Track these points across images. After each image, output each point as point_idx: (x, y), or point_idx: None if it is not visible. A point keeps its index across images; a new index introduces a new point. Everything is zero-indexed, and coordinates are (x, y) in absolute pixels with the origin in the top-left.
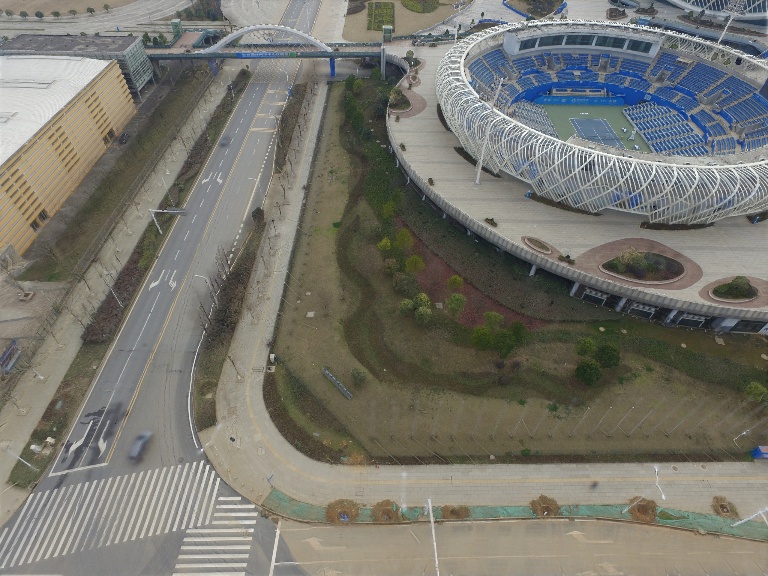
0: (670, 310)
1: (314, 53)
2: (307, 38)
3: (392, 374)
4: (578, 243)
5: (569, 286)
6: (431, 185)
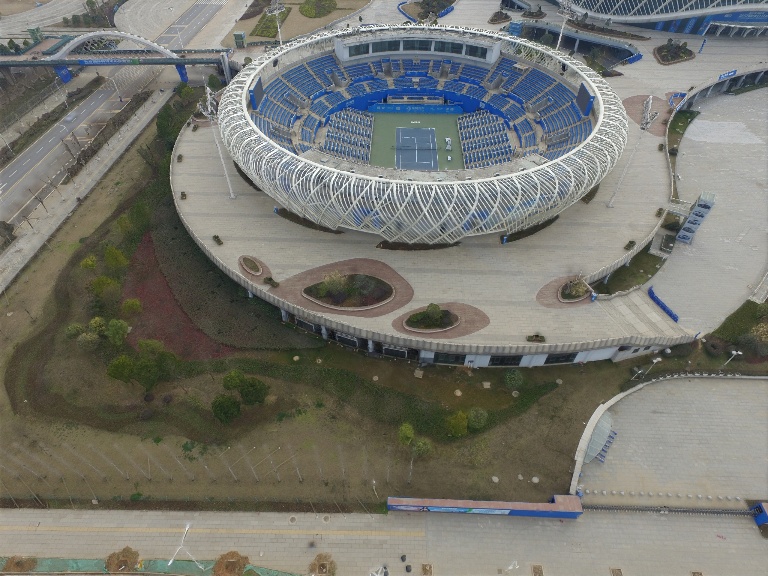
0: (366, 339)
1: (156, 60)
2: (149, 44)
3: (30, 406)
4: (297, 264)
5: (279, 310)
6: (182, 199)
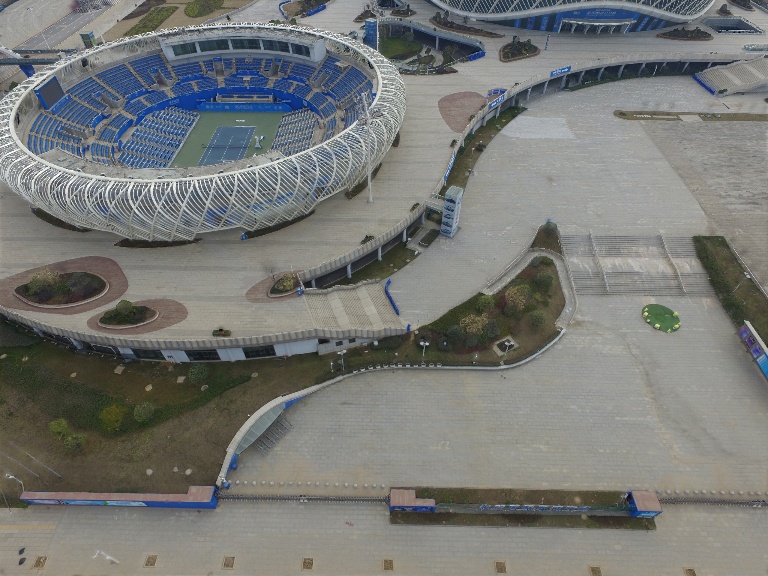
0: None
1: None
2: None
3: None
4: (26, 262)
5: None
6: None
